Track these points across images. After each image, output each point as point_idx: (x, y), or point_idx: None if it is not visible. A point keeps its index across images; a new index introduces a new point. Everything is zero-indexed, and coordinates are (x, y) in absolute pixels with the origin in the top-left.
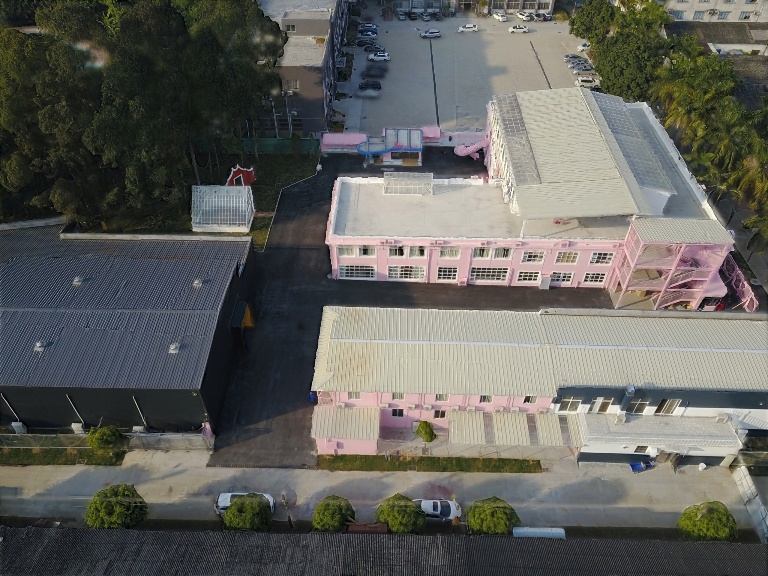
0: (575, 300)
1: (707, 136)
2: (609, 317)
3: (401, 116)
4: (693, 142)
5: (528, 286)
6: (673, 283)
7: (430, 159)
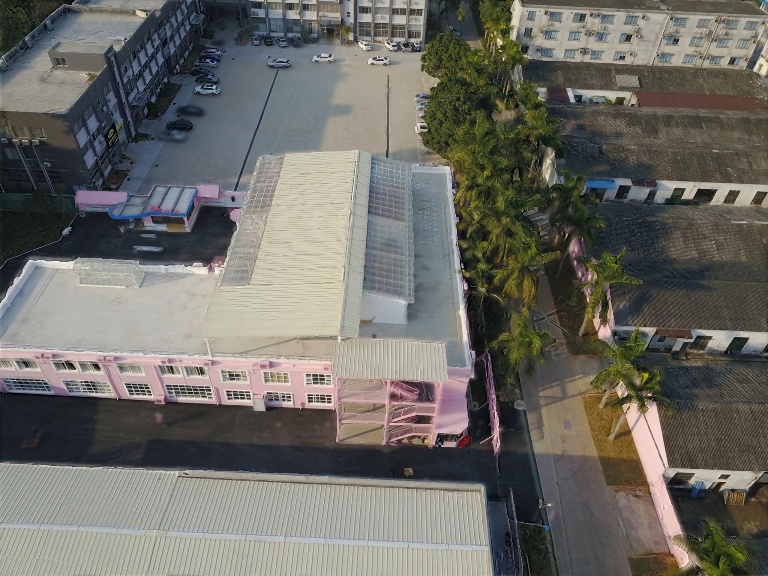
0: (292, 427)
1: (483, 221)
2: (265, 483)
3: (200, 165)
4: (469, 227)
5: (243, 405)
6: (396, 417)
7: (204, 223)
